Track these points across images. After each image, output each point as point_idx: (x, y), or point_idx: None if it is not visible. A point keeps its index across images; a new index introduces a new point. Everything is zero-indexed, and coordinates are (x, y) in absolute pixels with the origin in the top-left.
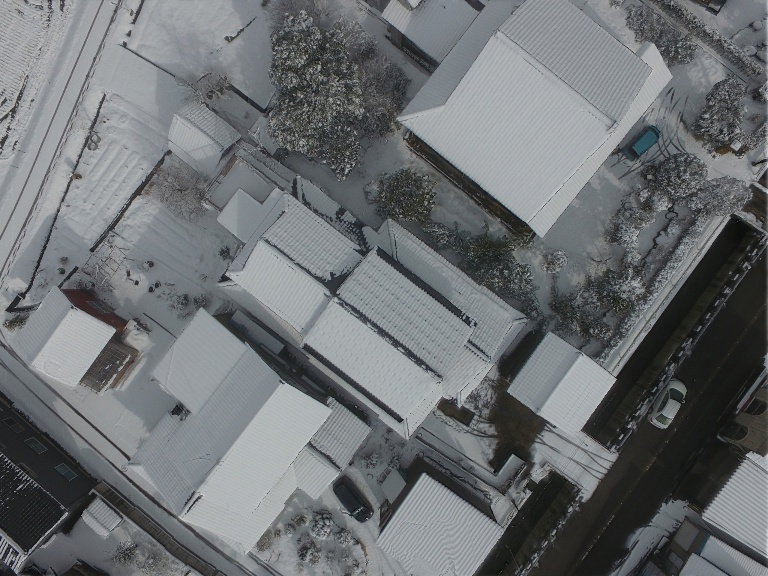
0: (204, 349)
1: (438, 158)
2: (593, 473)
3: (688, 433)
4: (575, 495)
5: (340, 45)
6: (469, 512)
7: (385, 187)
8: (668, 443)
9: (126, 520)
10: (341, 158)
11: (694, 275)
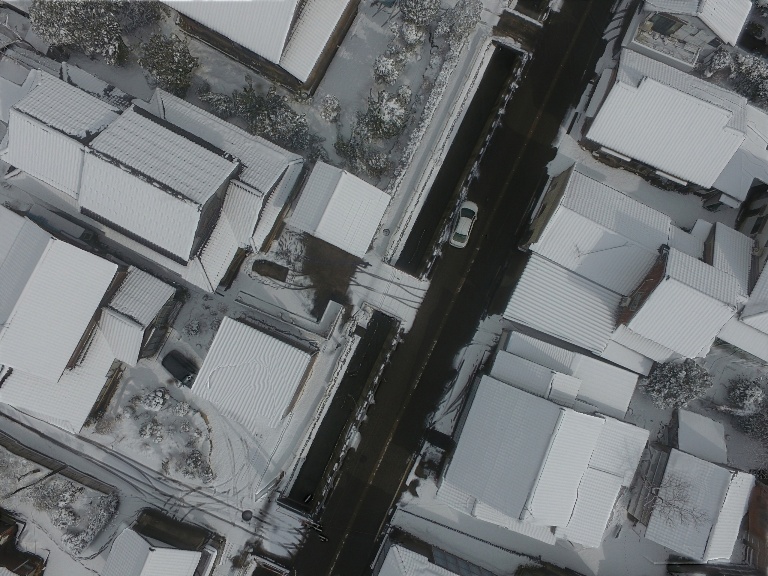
0: None
1: (209, 35)
2: (409, 304)
3: (490, 250)
4: (397, 329)
5: None
6: (275, 345)
7: None
8: (473, 263)
9: None
10: (100, 38)
11: (475, 107)
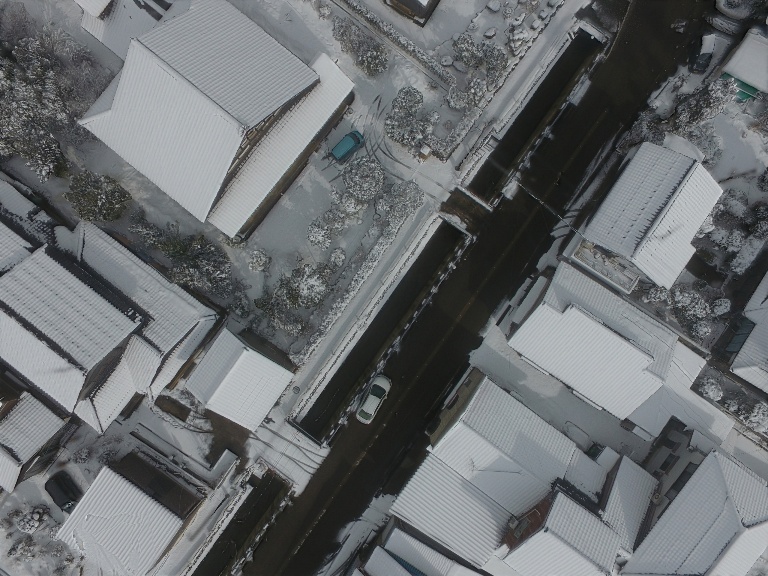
0: None
1: None
2: (305, 468)
3: (397, 428)
4: (289, 490)
5: (29, 52)
6: (149, 504)
7: None
8: (377, 438)
9: None
10: (34, 160)
11: (412, 275)
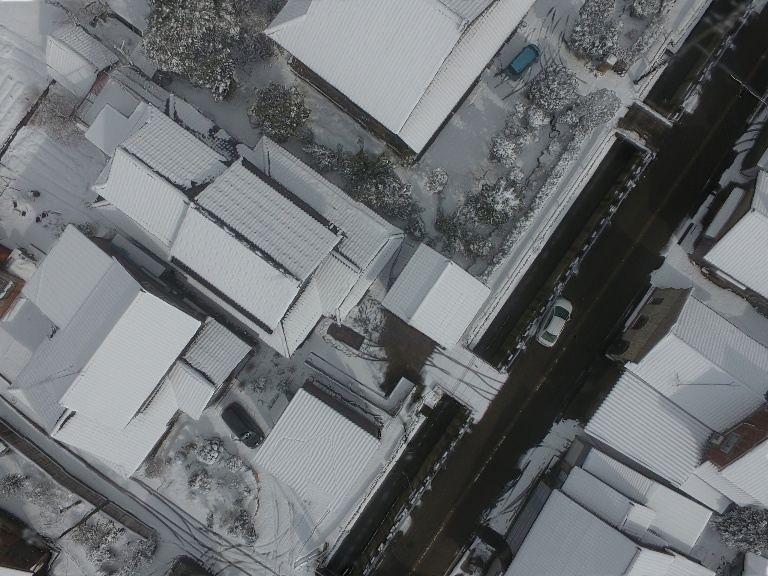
0: (72, 265)
1: (321, 81)
2: (483, 394)
3: (577, 352)
4: (466, 417)
5: None
6: (346, 427)
7: (256, 102)
8: (557, 363)
9: (11, 449)
10: (213, 75)
11: (583, 197)
